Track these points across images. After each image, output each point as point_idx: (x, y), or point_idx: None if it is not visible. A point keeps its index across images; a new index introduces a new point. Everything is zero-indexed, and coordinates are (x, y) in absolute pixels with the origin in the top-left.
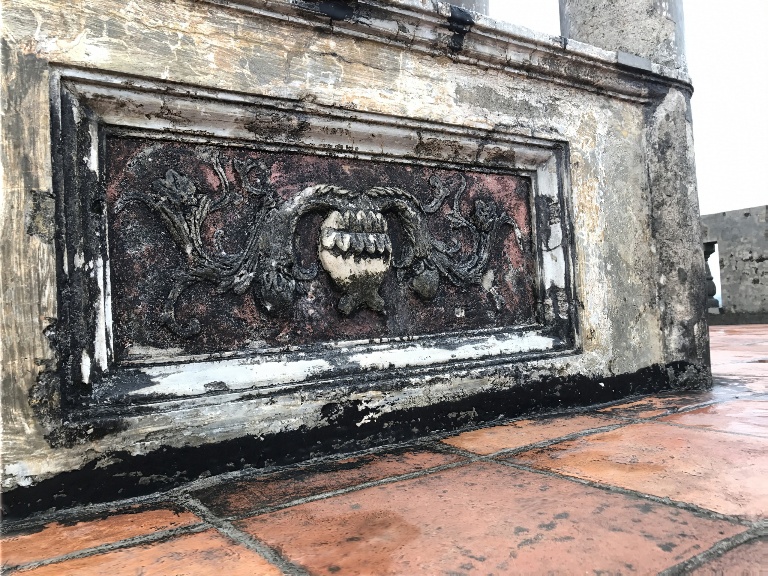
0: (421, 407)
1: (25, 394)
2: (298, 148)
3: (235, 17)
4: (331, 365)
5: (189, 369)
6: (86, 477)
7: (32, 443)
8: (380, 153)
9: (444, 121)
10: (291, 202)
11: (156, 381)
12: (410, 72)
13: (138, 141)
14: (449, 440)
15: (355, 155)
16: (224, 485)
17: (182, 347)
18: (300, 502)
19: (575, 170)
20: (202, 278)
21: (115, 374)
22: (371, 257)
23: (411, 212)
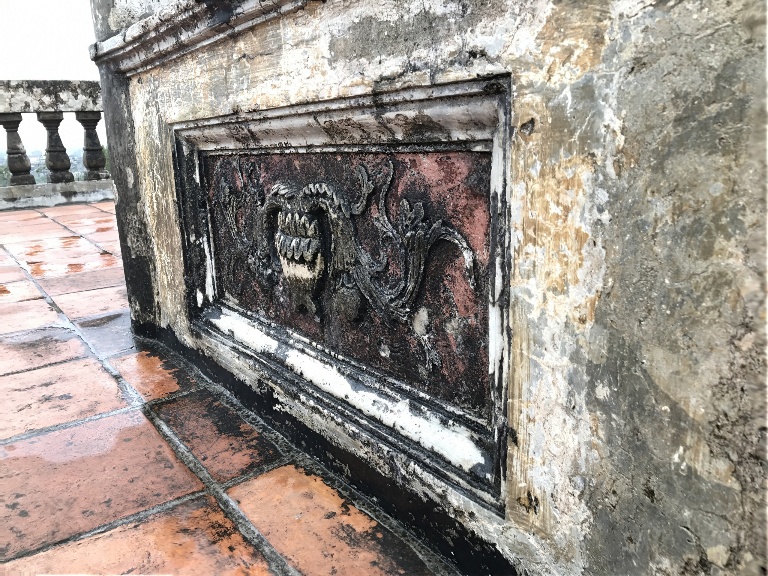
0: (307, 427)
1: (183, 304)
2: (266, 149)
3: (204, 53)
4: (275, 350)
5: None
6: (197, 355)
7: None
8: (307, 145)
9: (320, 98)
10: None
11: (221, 317)
12: (290, 43)
13: (215, 158)
14: (286, 469)
15: (296, 149)
16: None
17: (238, 300)
18: (157, 423)
19: (524, 141)
20: None
21: None
22: (297, 262)
23: (332, 215)
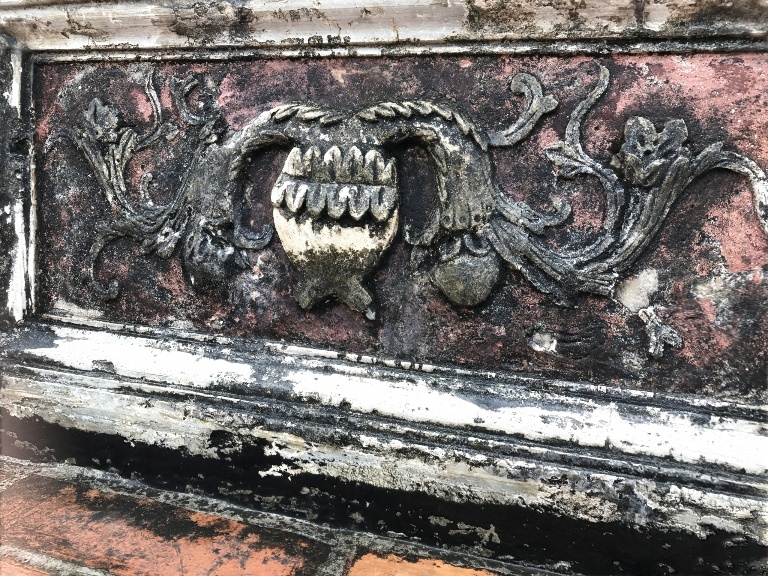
0: (375, 486)
1: None
2: (256, 50)
3: None
4: (252, 377)
5: (94, 338)
6: None
7: None
8: (395, 41)
9: None
10: (239, 134)
11: (57, 343)
12: None
13: (69, 66)
14: (371, 563)
15: (351, 50)
16: (58, 483)
17: (102, 311)
18: None
19: None
20: (123, 233)
21: (30, 326)
22: (343, 224)
23: (448, 146)
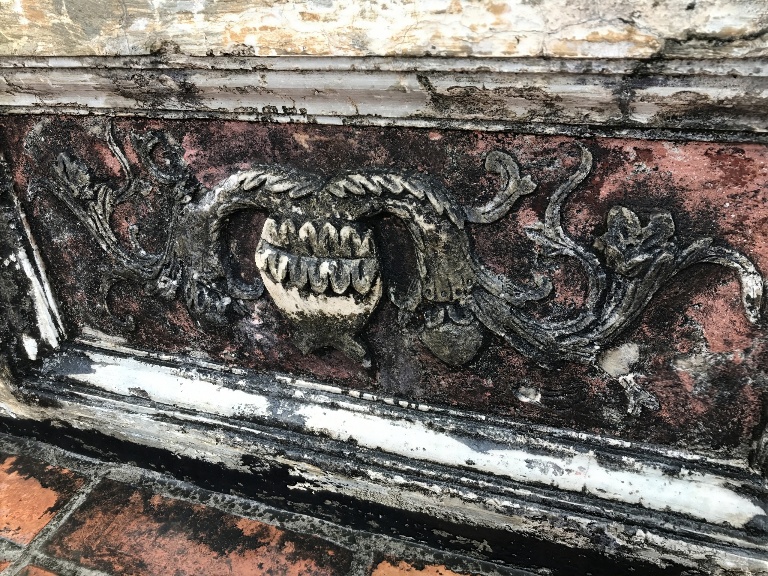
0: (385, 505)
1: None
2: (210, 112)
3: None
4: (268, 410)
5: (125, 364)
6: (47, 428)
7: (6, 393)
8: (355, 114)
9: (476, 52)
10: (212, 195)
11: (94, 369)
12: None
13: (25, 117)
14: (385, 573)
15: (310, 118)
16: (126, 488)
17: (125, 338)
18: None
19: None
20: (125, 277)
21: (66, 351)
22: (328, 294)
23: (423, 225)
